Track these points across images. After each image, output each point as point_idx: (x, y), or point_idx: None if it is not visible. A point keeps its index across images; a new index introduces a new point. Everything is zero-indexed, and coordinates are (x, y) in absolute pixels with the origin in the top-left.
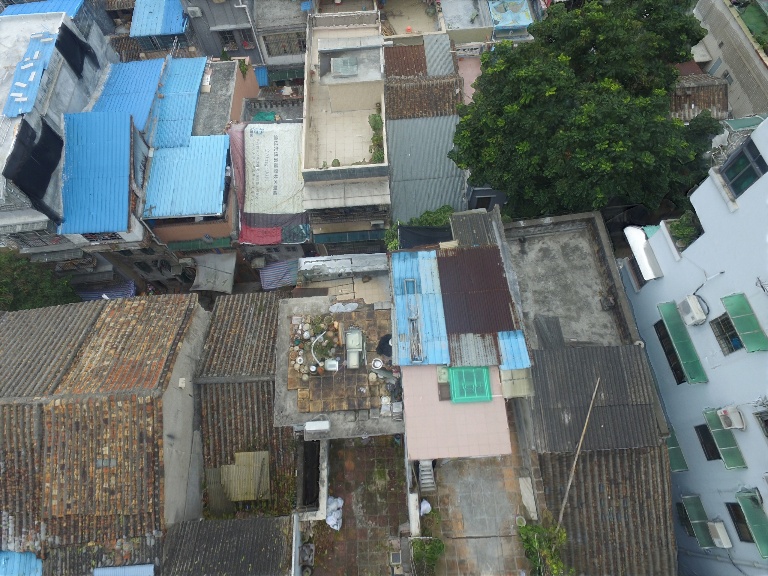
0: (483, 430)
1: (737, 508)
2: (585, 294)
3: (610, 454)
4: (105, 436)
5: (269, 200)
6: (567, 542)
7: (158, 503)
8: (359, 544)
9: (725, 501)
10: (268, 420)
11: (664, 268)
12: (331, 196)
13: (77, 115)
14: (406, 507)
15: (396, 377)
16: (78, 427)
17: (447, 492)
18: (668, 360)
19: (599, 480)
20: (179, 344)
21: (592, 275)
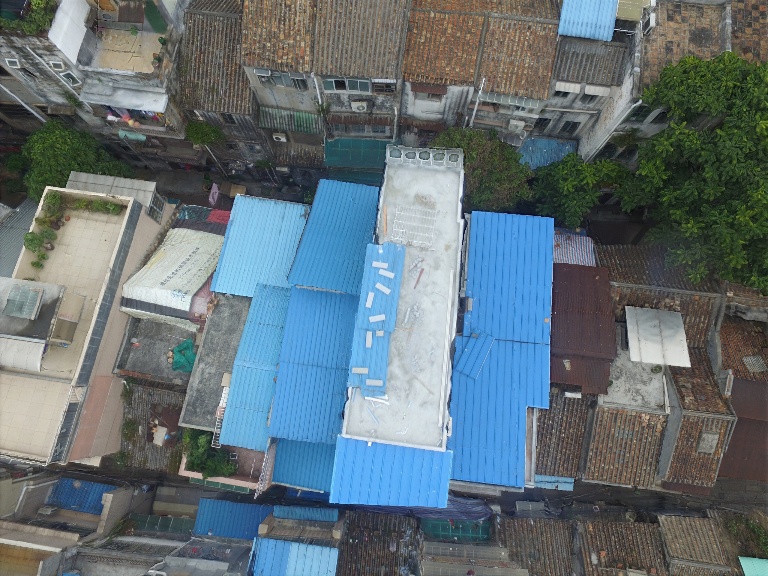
0: None
1: None
2: None
3: None
4: None
5: (207, 245)
6: None
7: None
8: None
9: None
10: None
11: None
12: (125, 191)
13: (348, 290)
14: None
15: None
16: None
17: None
18: None
19: None
20: (240, 2)
21: None
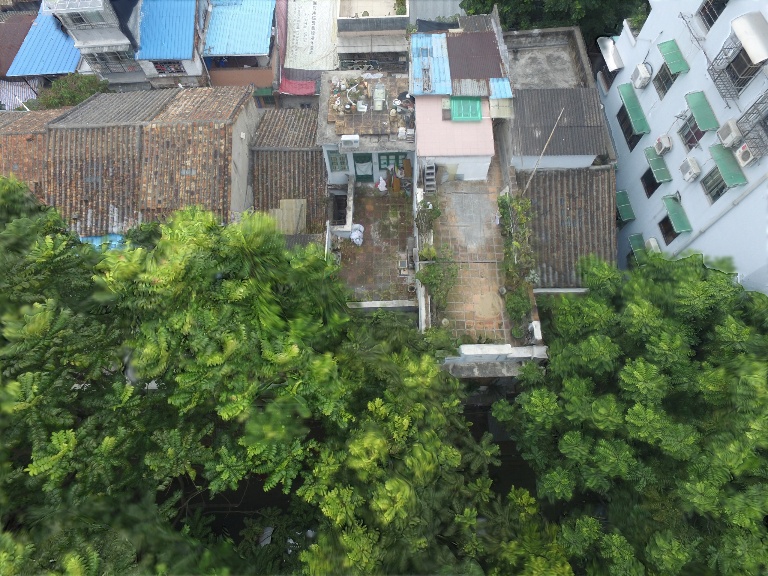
0: (474, 139)
1: (666, 224)
2: (562, 86)
3: (570, 175)
4: (188, 153)
5: (306, 58)
6: (534, 240)
7: (226, 202)
8: (375, 255)
9: (658, 222)
10: (306, 182)
11: (625, 60)
12: (360, 44)
13: None
14: (412, 234)
15: (411, 111)
16: (168, 145)
17: (445, 199)
18: (625, 137)
19: (561, 195)
20: (242, 105)
21: (569, 75)
